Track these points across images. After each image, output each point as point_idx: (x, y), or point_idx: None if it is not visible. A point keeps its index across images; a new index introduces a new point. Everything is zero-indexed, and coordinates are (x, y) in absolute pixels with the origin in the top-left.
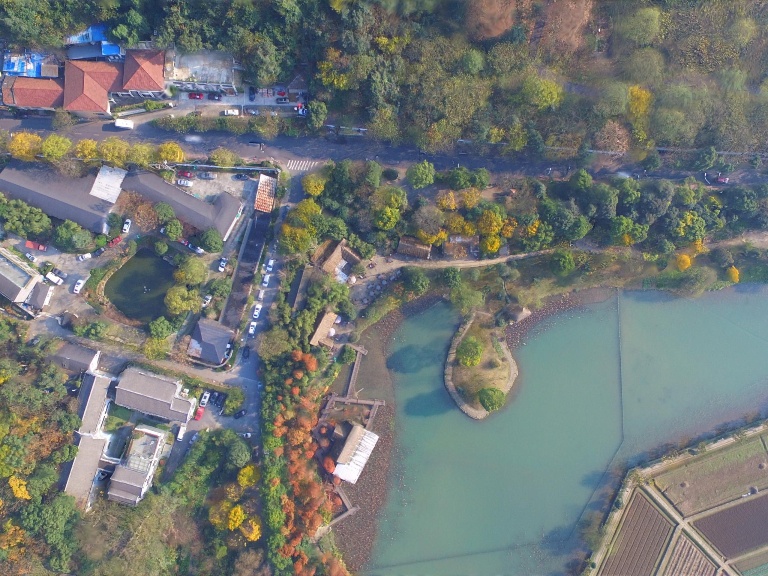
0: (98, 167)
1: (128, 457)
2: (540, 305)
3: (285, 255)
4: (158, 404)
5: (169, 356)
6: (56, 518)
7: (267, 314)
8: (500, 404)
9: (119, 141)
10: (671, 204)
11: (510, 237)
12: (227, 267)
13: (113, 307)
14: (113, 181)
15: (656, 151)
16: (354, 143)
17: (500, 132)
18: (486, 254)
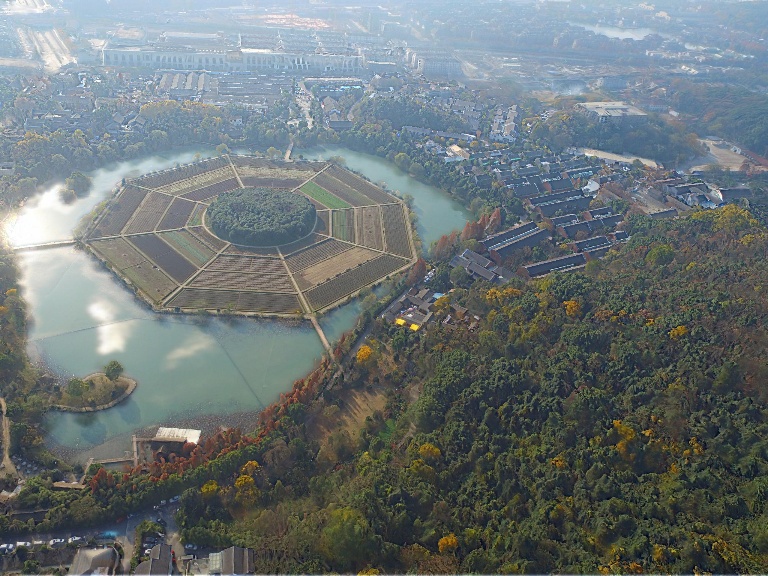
0: None
1: (212, 572)
2: (39, 369)
3: None
4: (156, 571)
5: None
6: None
7: (57, 524)
8: None
9: None
10: None
11: None
12: (7, 575)
13: None
14: None
15: None
16: None
17: None
18: None
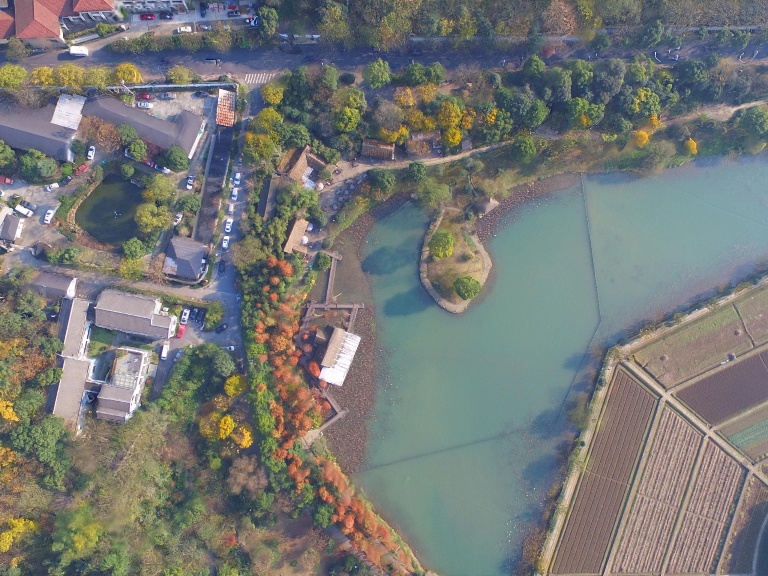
0: (57, 96)
1: (113, 375)
2: (506, 194)
3: (250, 164)
4: (138, 321)
5: (145, 277)
6: (46, 437)
7: (238, 225)
8: (475, 290)
9: (75, 66)
10: (624, 82)
11: (470, 128)
12: (194, 183)
13: (85, 233)
14: (73, 108)
15: (604, 30)
16: (309, 52)
17: (450, 23)
18: (449, 149)
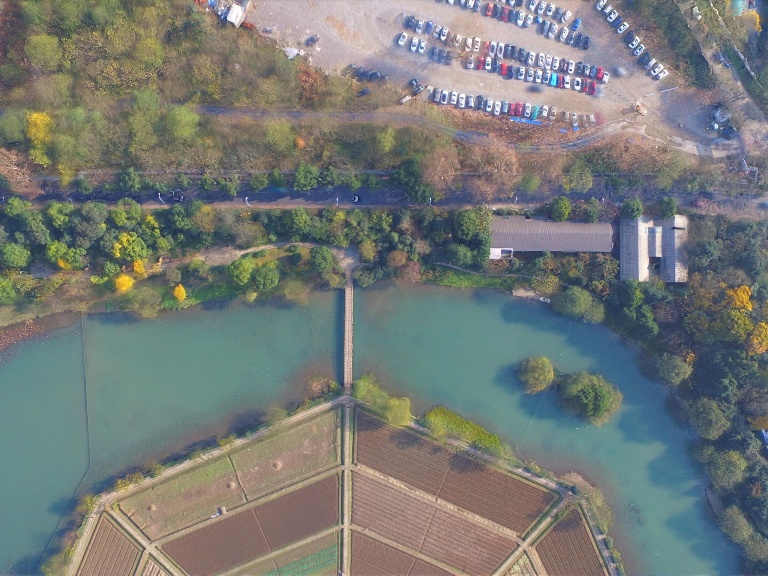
0: None
1: None
2: None
3: None
4: None
5: None
6: None
7: None
8: None
9: None
10: (108, 226)
11: None
12: None
13: None
14: None
15: (80, 175)
16: None
17: None
18: None
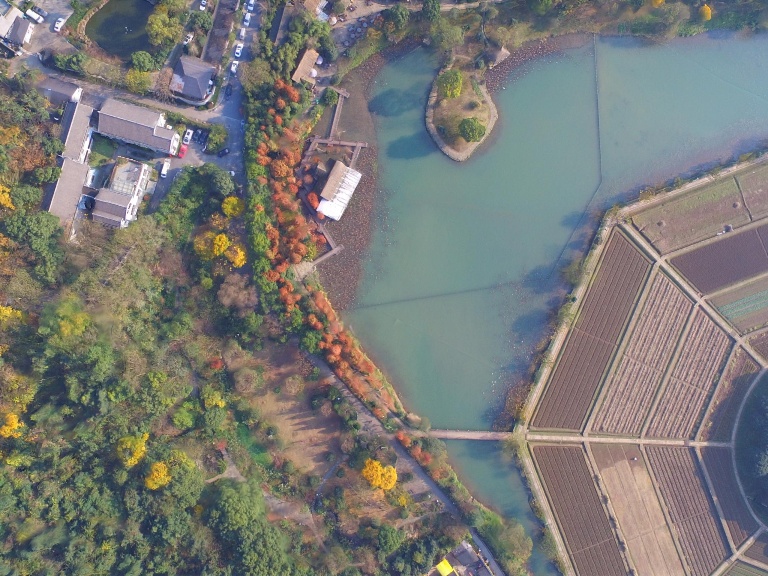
0: None
1: (112, 180)
2: (518, 44)
3: None
4: (141, 130)
5: (151, 92)
6: (40, 227)
7: (249, 47)
8: (480, 131)
9: None
10: None
11: None
12: (208, 1)
13: (94, 43)
14: None
15: None
16: None
17: None
18: None
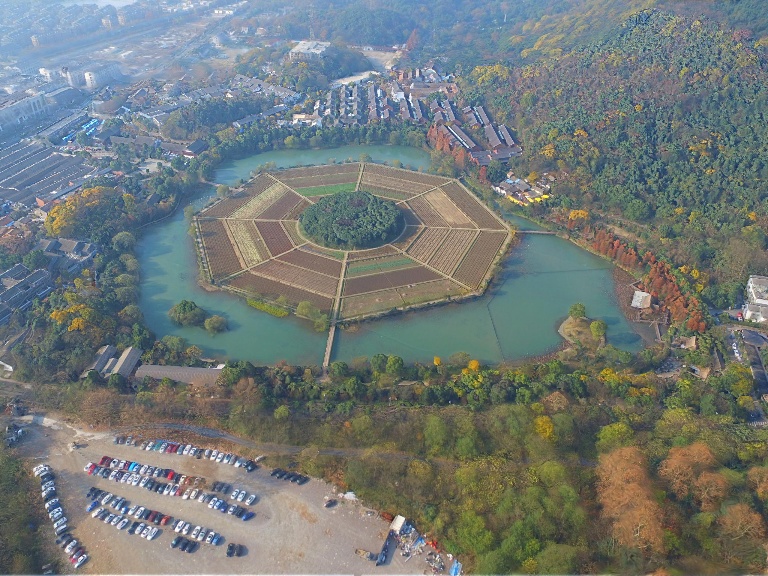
0: None
1: None
2: None
3: None
4: None
5: None
6: None
7: None
8: None
9: None
10: None
11: None
12: None
13: None
14: None
15: None
16: None
17: (633, 418)
18: None
